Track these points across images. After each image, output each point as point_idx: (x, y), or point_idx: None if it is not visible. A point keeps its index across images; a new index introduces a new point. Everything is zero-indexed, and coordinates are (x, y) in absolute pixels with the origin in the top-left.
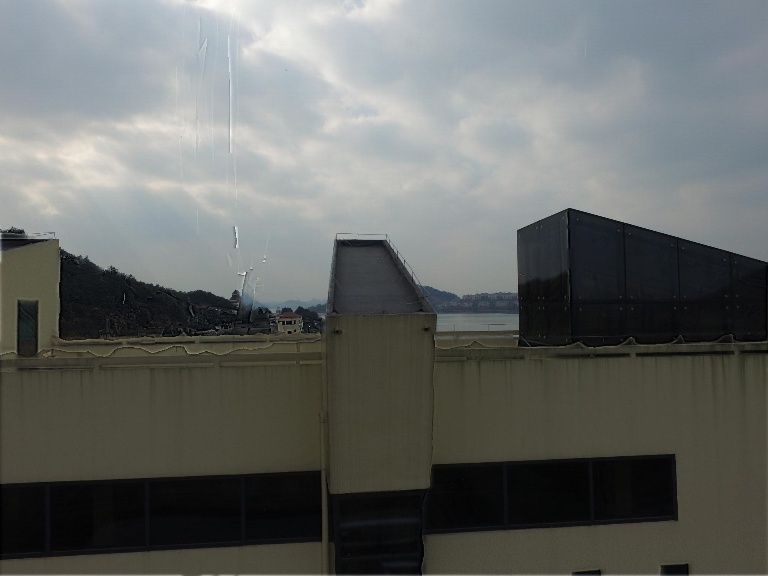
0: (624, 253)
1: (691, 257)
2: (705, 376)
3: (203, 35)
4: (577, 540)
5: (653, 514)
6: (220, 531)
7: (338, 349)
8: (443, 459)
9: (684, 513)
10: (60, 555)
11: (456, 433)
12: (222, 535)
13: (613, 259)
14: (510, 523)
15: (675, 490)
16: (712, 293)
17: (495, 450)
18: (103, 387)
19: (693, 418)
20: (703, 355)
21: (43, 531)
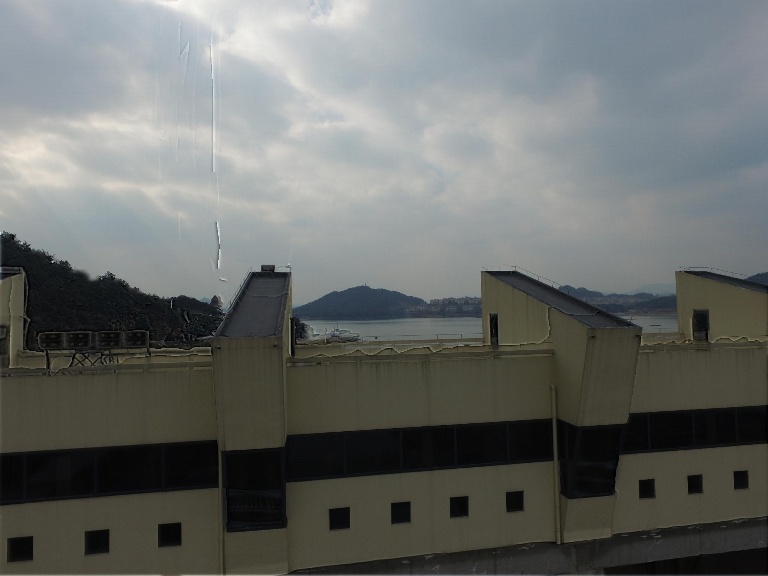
0: None
1: None
2: None
3: (184, 38)
4: None
5: None
6: (766, 435)
7: None
8: None
9: None
10: (700, 448)
11: None
12: (767, 437)
13: None
14: None
15: None
16: None
17: None
18: (715, 359)
19: None
20: None
21: (692, 436)
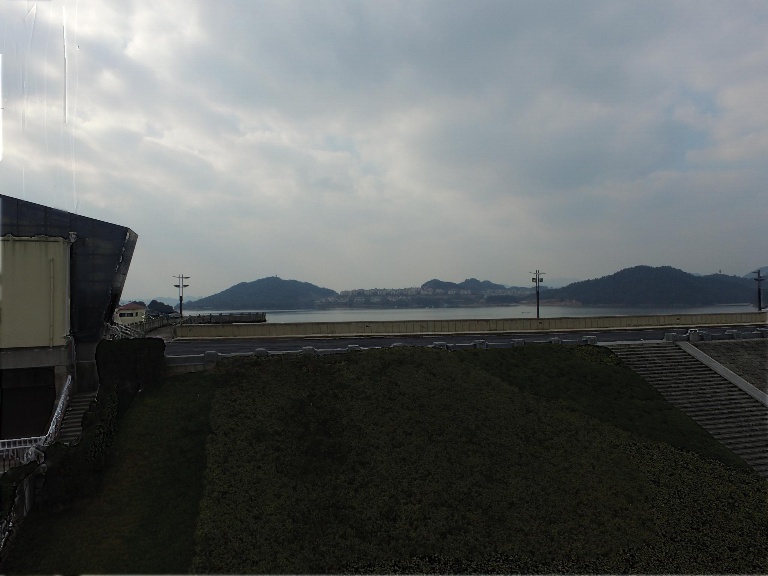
0: None
1: (25, 207)
2: None
3: None
4: None
5: None
6: None
7: None
8: None
9: None
10: None
11: None
12: None
13: None
14: None
15: None
16: (36, 222)
17: None
18: None
19: None
20: None
21: None
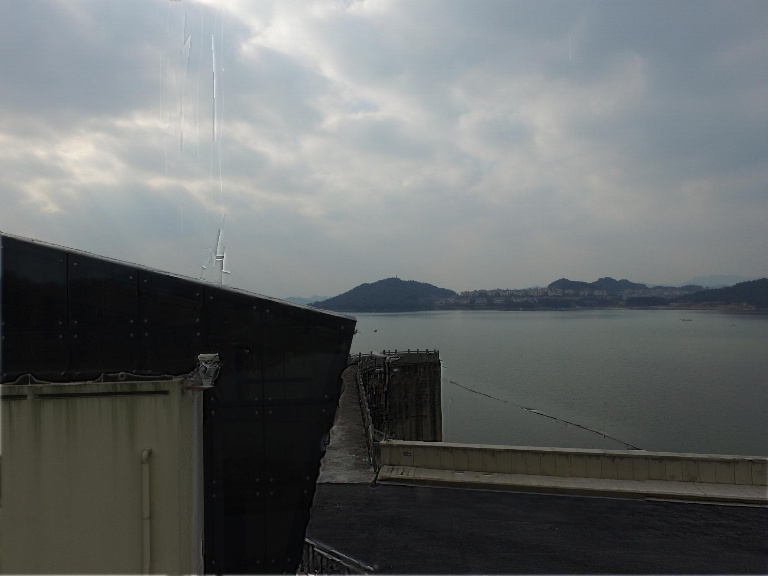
0: None
1: (87, 275)
2: None
3: (188, 31)
4: None
5: None
6: None
7: None
8: None
9: None
10: None
11: None
12: None
13: None
14: None
15: None
16: (115, 318)
17: None
18: None
19: None
20: None
21: None
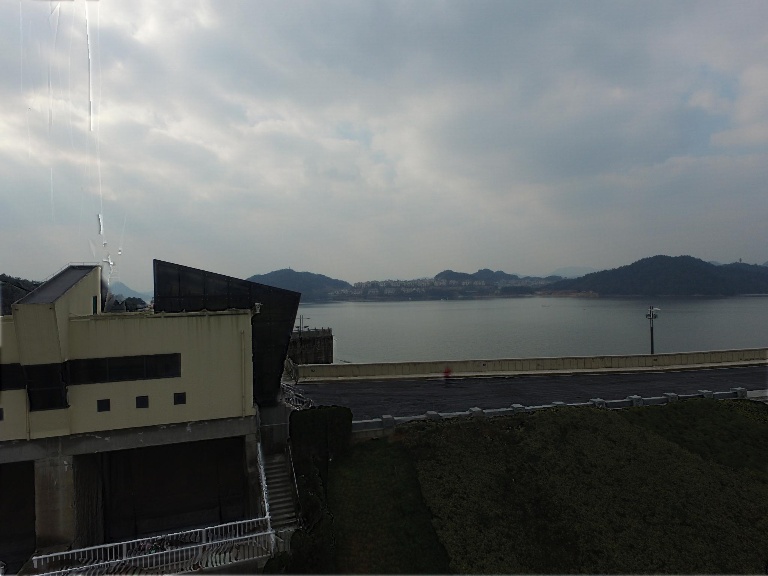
0: (179, 277)
1: (210, 279)
2: (193, 324)
3: None
4: (139, 385)
5: (171, 375)
6: None
7: (18, 315)
8: (81, 357)
9: (184, 374)
10: None
11: (87, 348)
12: None
13: (177, 279)
14: (110, 380)
15: (180, 366)
16: (220, 293)
17: (103, 353)
18: None
19: (189, 340)
20: (193, 317)
21: None
